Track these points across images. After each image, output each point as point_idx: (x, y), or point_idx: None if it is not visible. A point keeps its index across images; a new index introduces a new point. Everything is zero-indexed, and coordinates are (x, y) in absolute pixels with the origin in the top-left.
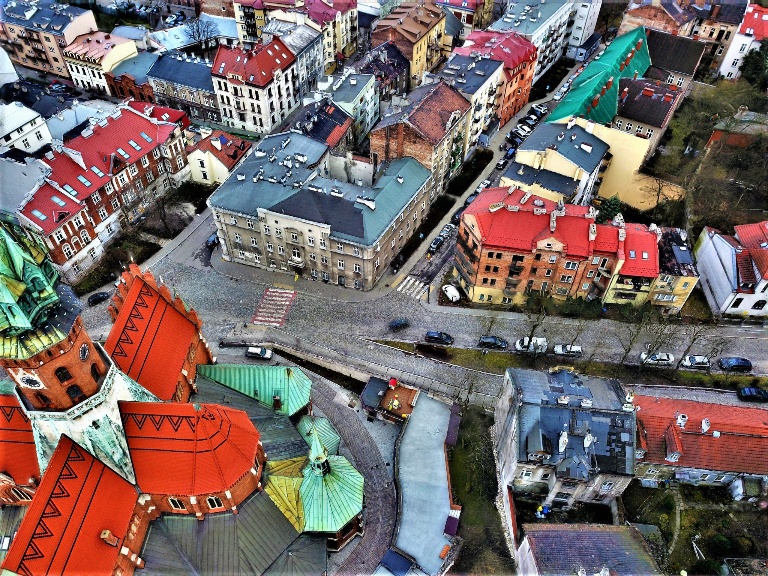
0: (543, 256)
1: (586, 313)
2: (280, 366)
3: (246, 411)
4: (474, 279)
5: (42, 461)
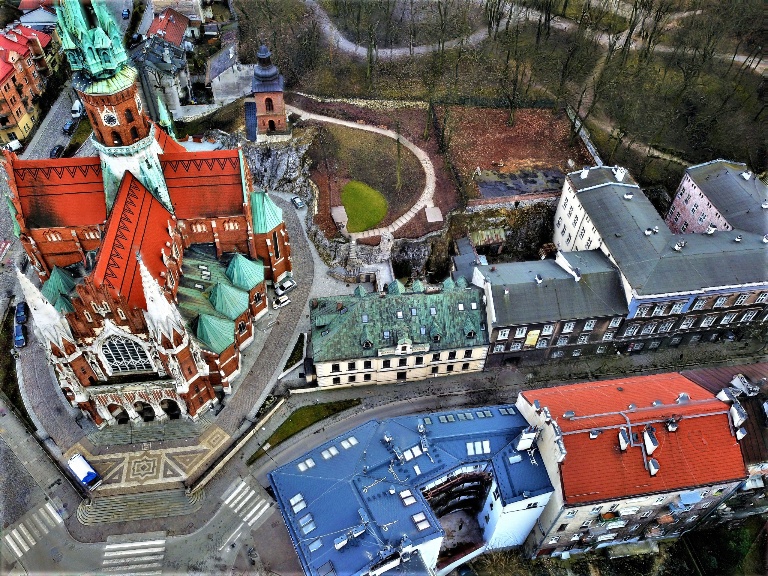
0: (17, 70)
1: (59, 85)
2: None
3: None
4: (13, 119)
5: None
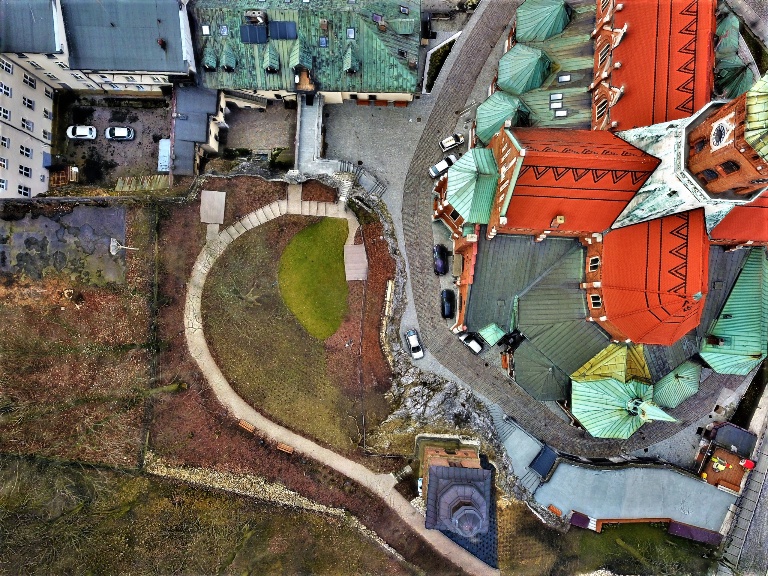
0: None
1: None
2: (767, 336)
3: (704, 307)
4: None
5: (633, 135)
